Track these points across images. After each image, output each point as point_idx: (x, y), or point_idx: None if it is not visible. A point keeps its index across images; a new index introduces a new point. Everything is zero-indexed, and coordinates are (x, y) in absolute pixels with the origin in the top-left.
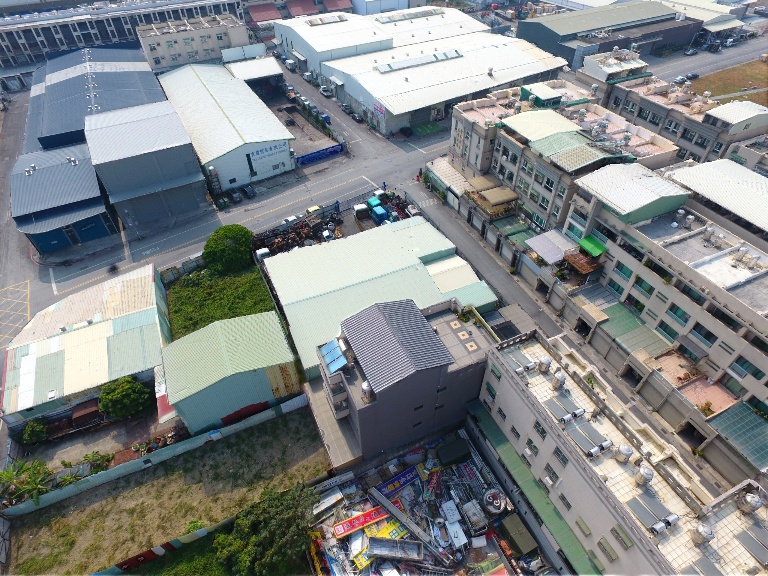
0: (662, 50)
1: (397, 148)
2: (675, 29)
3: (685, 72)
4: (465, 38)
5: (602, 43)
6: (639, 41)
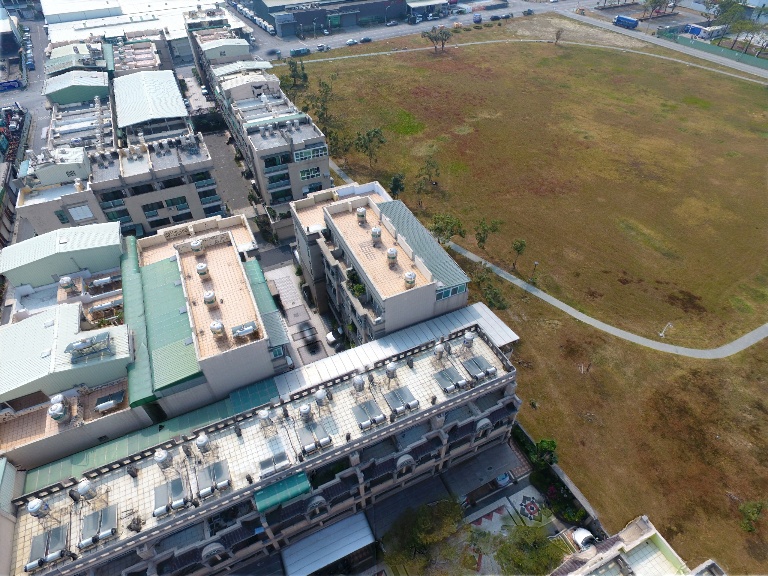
0: (368, 22)
1: None
2: (375, 4)
3: None
4: (189, 8)
5: (296, 13)
6: (335, 12)
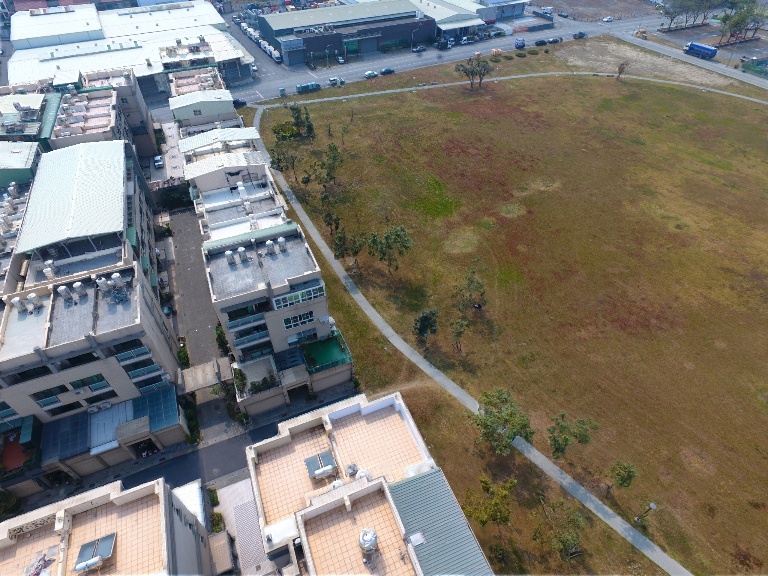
0: (391, 46)
1: None
2: (400, 26)
3: (388, 67)
4: None
5: (306, 38)
6: (352, 37)
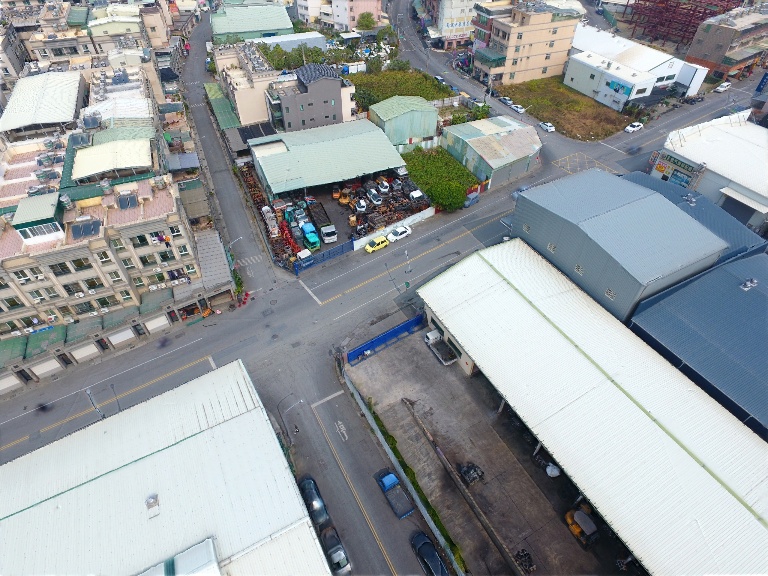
0: None
1: (253, 373)
2: None
3: None
4: None
5: None
6: None
